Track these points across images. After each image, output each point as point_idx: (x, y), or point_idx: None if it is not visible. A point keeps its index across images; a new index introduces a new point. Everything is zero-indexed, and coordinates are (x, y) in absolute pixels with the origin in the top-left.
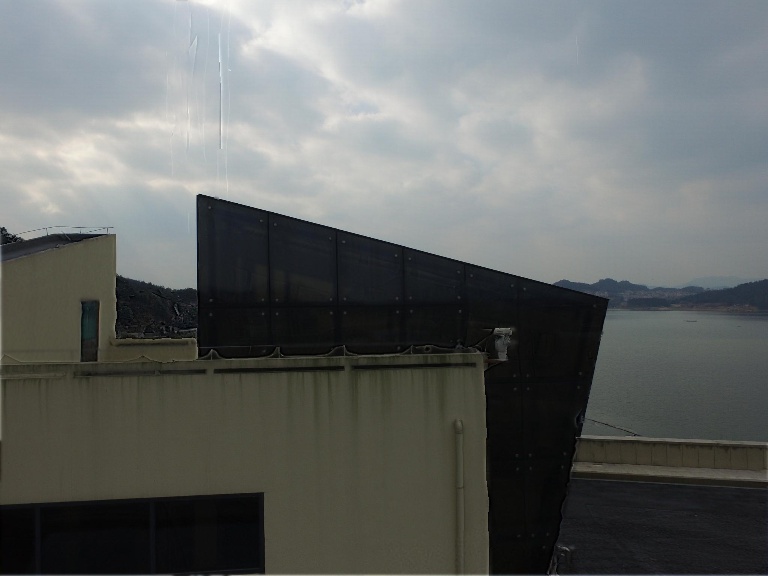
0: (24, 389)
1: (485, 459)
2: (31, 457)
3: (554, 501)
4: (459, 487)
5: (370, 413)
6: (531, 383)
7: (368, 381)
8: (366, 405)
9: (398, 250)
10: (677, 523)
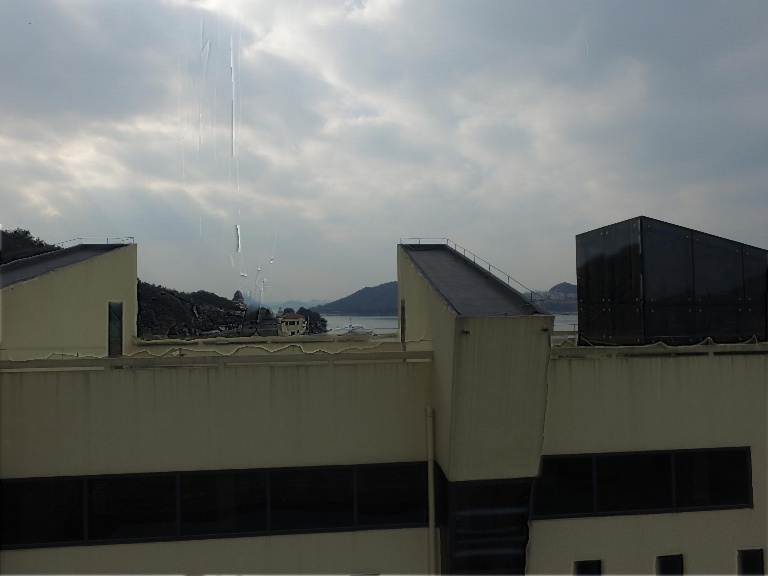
0: (583, 366)
1: None
2: (586, 418)
3: None
4: None
5: None
6: None
7: None
8: None
9: None
10: None
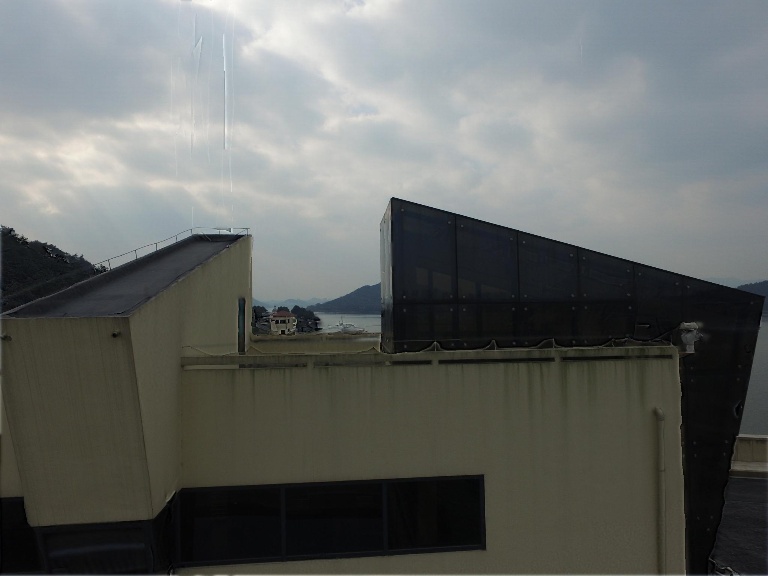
0: (270, 378)
1: None
2: (276, 441)
3: (715, 486)
4: (661, 470)
5: (578, 401)
6: (693, 375)
7: (576, 371)
8: (574, 394)
9: (573, 250)
10: (767, 514)
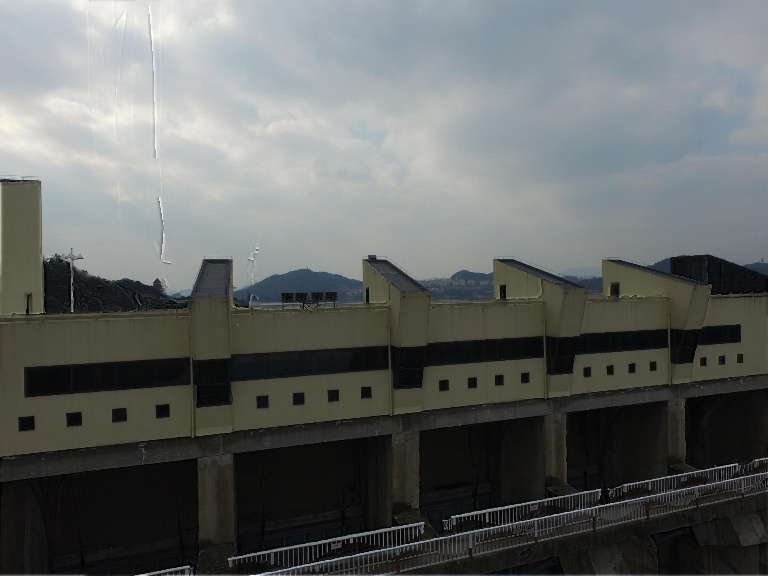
0: None
1: None
2: None
3: None
4: None
5: (757, 307)
6: None
7: (757, 299)
8: (757, 305)
9: (744, 268)
10: None
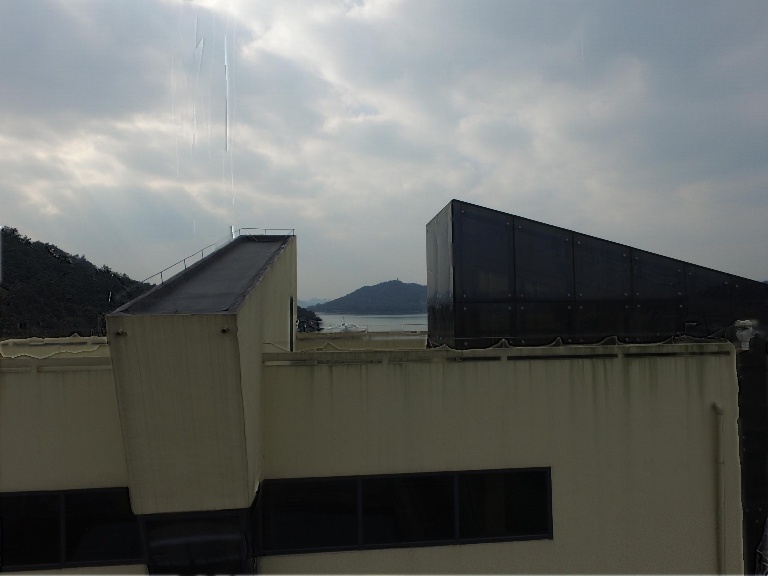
0: (347, 373)
1: (738, 438)
2: (352, 434)
3: (763, 480)
4: (721, 462)
5: (640, 396)
6: None
7: (638, 367)
8: (636, 389)
9: (626, 250)
10: None
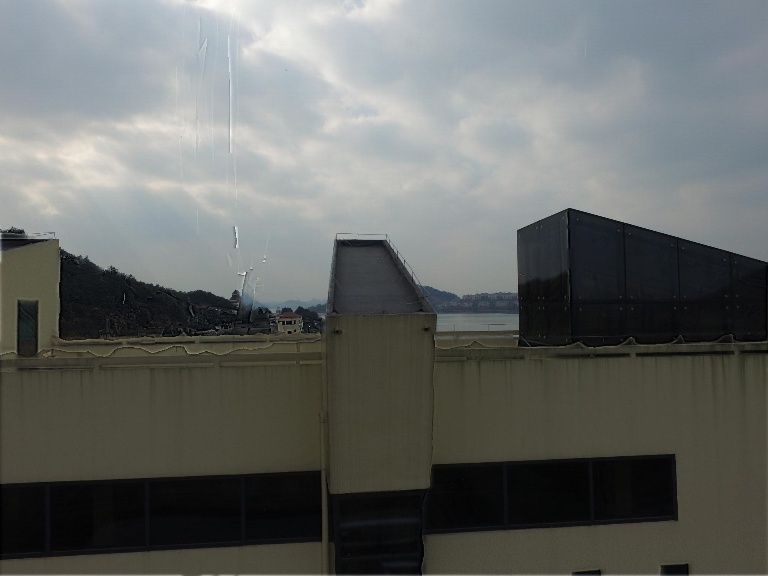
0: (494, 369)
1: None
2: (497, 424)
3: None
4: None
5: (754, 389)
6: None
7: (753, 363)
8: (751, 383)
9: (725, 255)
10: None
